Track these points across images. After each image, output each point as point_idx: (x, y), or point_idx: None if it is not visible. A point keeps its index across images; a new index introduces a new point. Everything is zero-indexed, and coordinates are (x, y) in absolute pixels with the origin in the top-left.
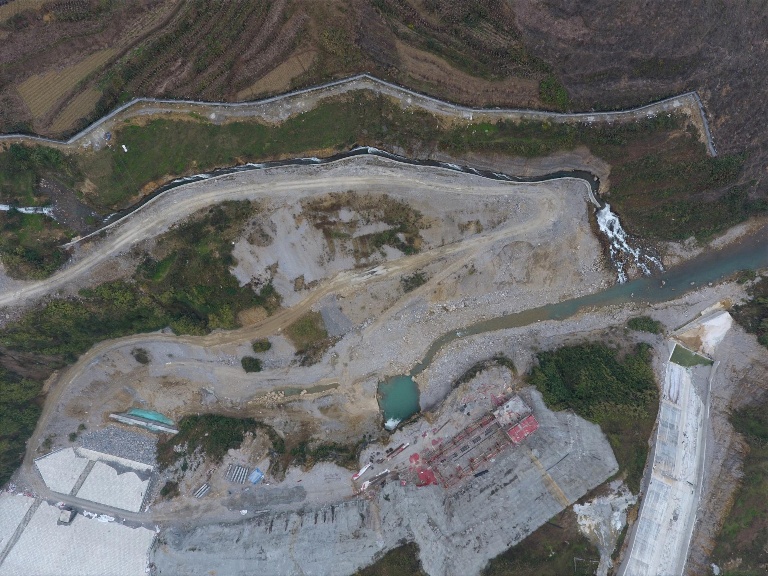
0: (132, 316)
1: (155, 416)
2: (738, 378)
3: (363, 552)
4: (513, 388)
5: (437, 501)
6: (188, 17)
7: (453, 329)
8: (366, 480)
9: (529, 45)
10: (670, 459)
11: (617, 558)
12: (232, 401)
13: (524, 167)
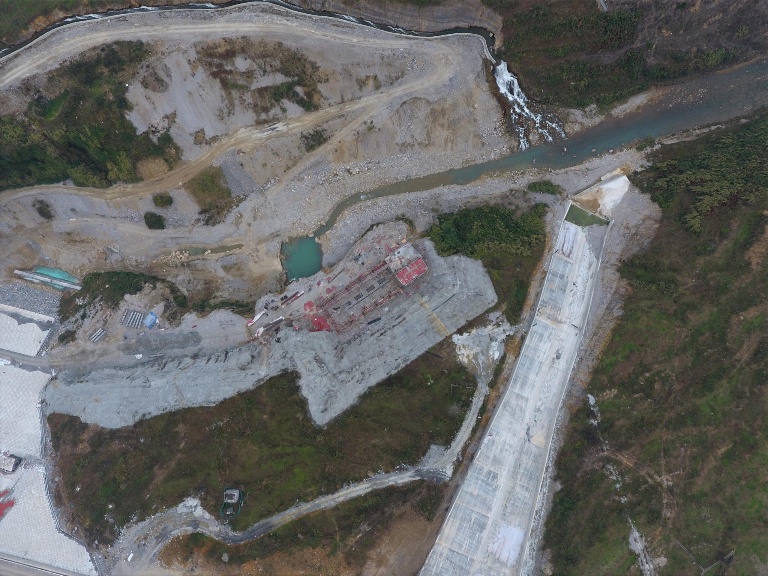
0: (25, 155)
1: (61, 275)
2: (630, 233)
3: (245, 379)
4: None
5: (328, 344)
6: None
7: (357, 192)
8: (260, 327)
9: None
10: (557, 304)
11: (497, 390)
12: (137, 260)
13: (418, 19)
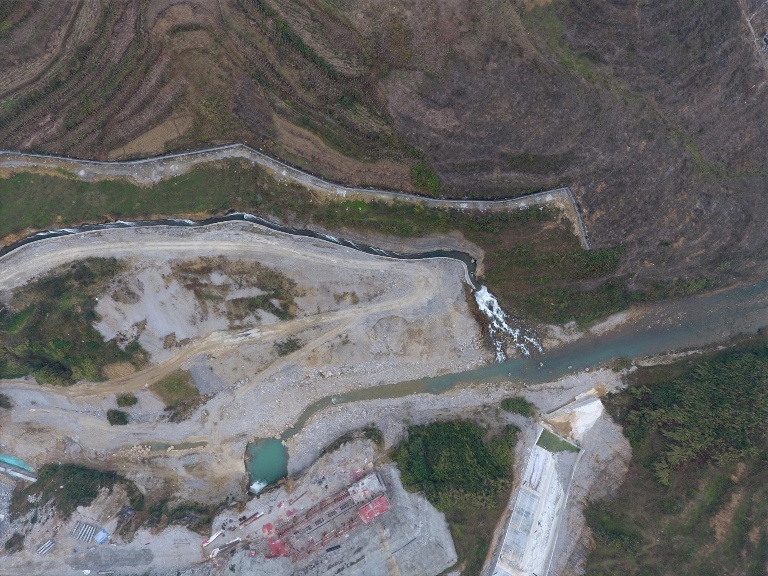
0: None
1: (16, 461)
2: (599, 469)
3: None
4: (375, 463)
5: (283, 575)
6: (60, 75)
7: (328, 395)
8: (216, 547)
9: (401, 131)
10: (519, 549)
11: None
12: (97, 452)
13: (400, 245)
